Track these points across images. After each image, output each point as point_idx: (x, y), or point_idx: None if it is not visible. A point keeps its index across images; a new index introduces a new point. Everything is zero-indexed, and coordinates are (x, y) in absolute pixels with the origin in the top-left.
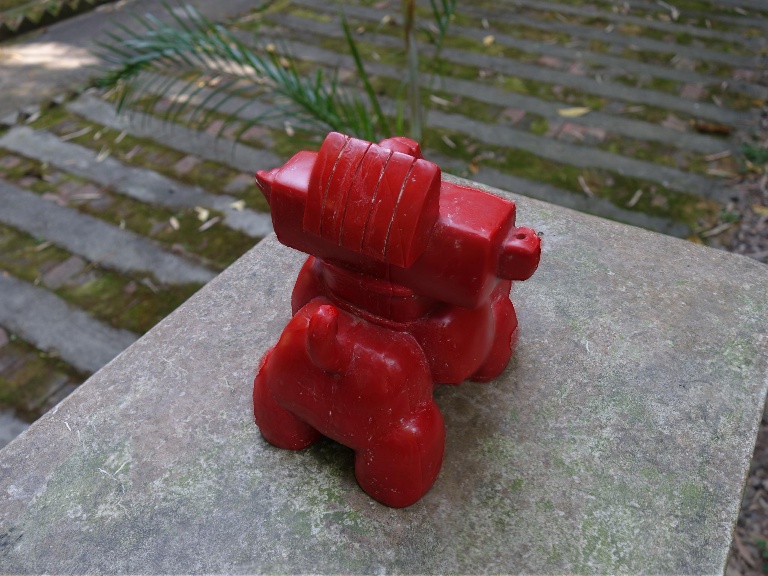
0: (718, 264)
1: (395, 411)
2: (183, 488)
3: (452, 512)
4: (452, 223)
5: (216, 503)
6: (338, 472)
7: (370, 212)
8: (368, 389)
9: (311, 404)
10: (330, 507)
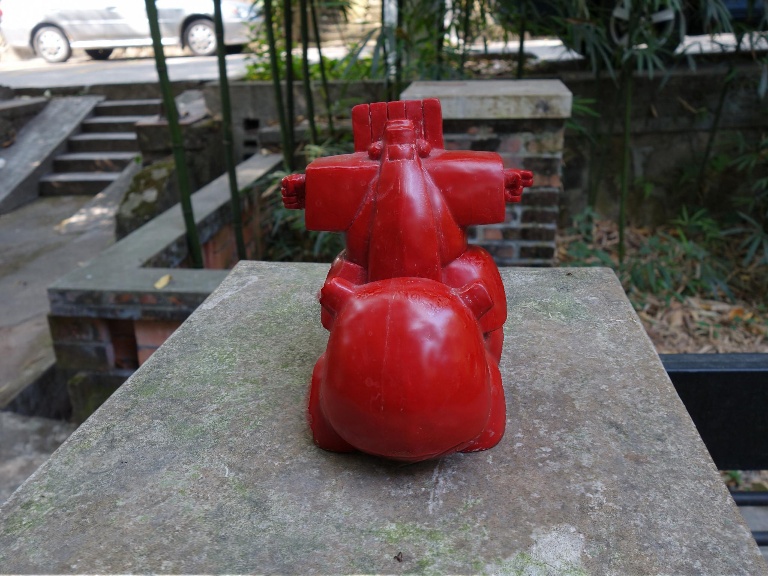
0: None
1: None
2: None
3: None
4: None
5: None
6: None
7: None
8: None
9: None
10: None
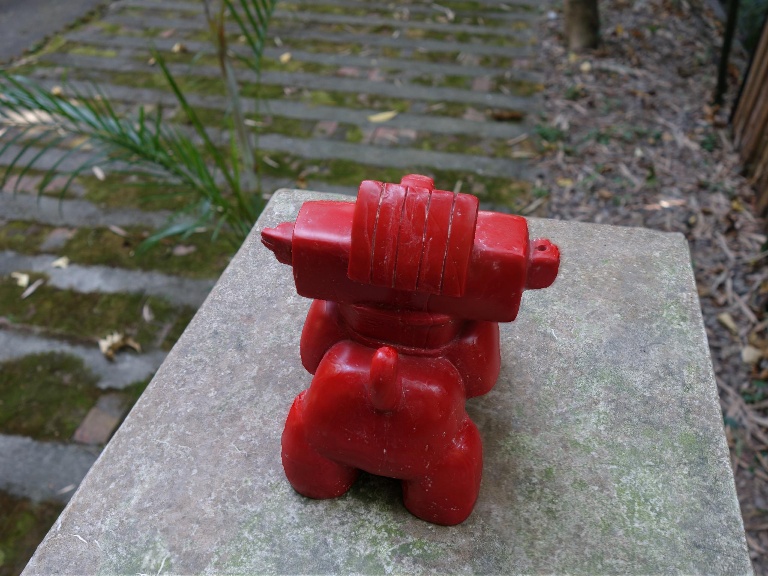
0: (627, 239)
1: (448, 433)
2: (239, 567)
3: (505, 514)
4: (487, 247)
5: (279, 572)
6: (386, 507)
7: (423, 251)
8: (422, 419)
9: (362, 447)
10: (393, 542)
